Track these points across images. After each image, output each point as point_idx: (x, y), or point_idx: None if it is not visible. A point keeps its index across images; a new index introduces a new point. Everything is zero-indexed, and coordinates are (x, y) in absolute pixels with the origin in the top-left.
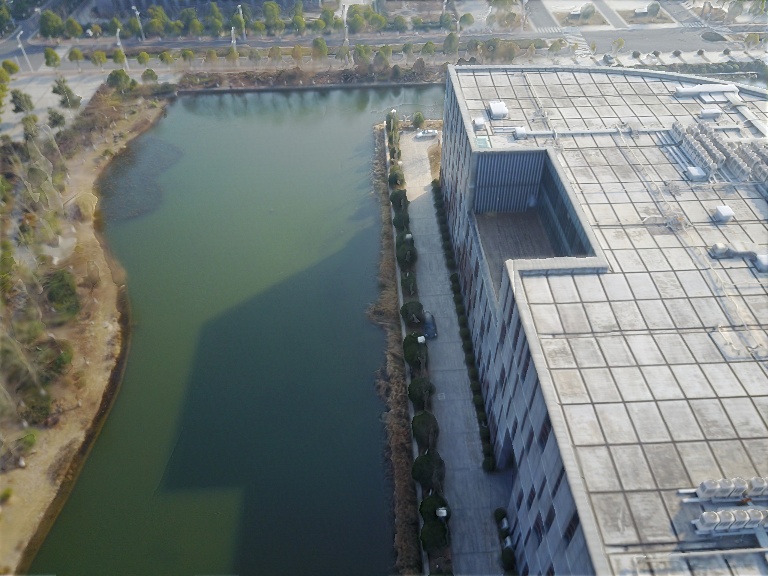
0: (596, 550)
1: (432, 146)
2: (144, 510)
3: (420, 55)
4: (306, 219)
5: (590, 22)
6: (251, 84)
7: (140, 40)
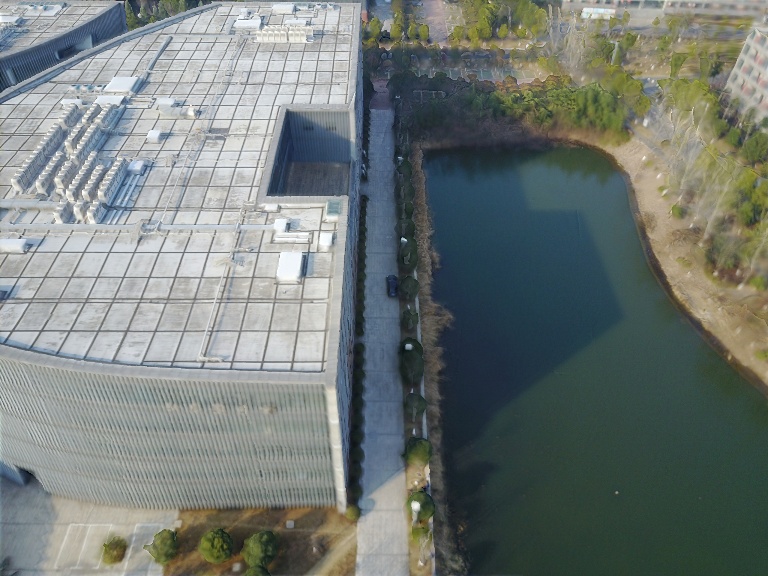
0: None
1: None
2: (579, 204)
3: None
4: None
5: None
6: None
7: None
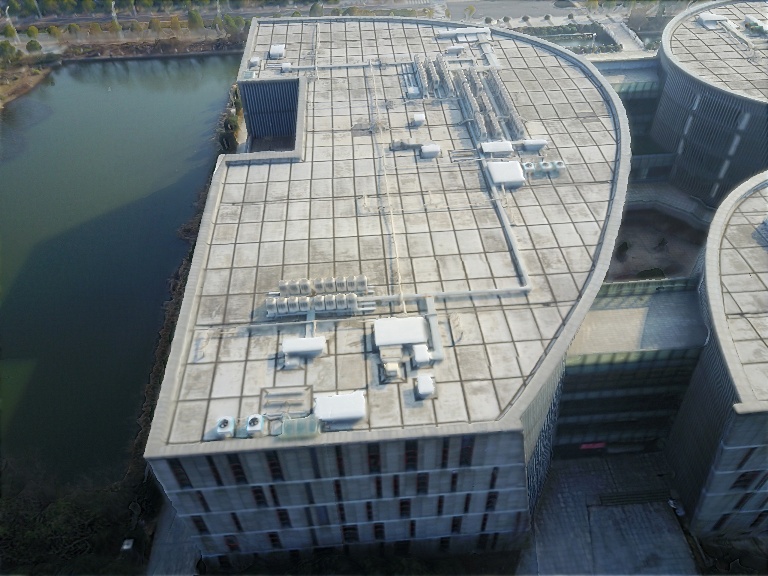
0: (181, 325)
1: None
2: None
3: None
4: None
5: None
6: (130, 53)
7: (38, 18)
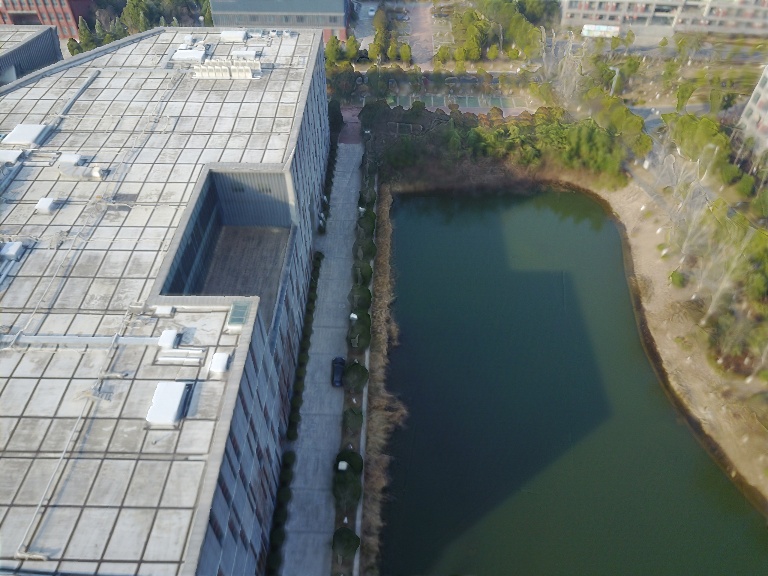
0: None
1: None
2: (565, 264)
3: None
4: None
5: None
6: None
7: None
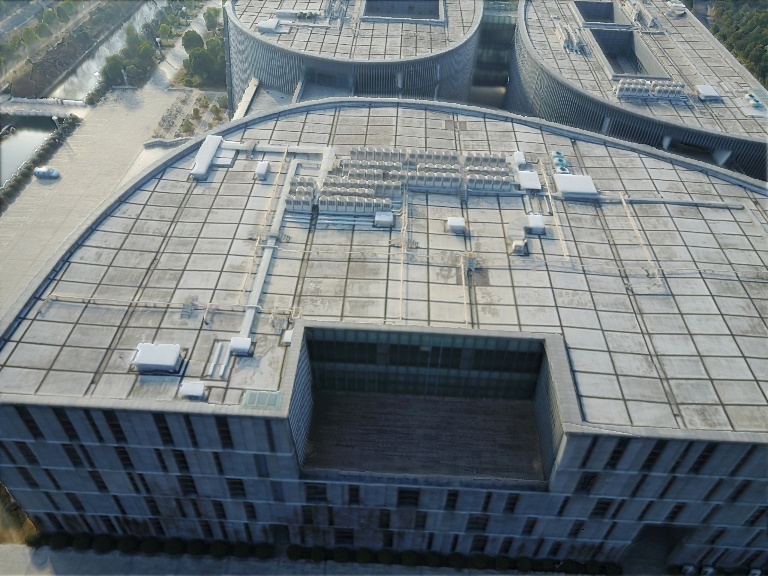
0: None
1: None
2: None
3: None
4: None
5: None
6: None
7: None
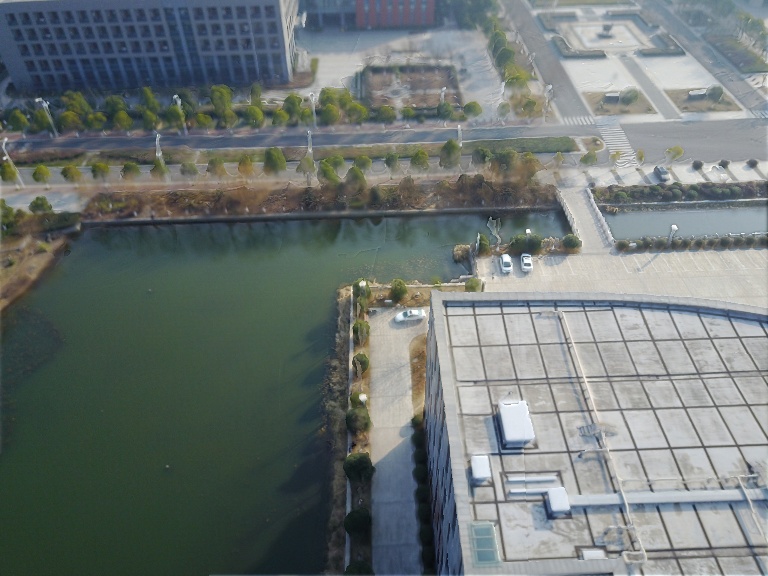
0: None
1: (417, 339)
2: None
3: (409, 168)
4: (216, 488)
5: (631, 109)
6: (180, 212)
7: (52, 136)
